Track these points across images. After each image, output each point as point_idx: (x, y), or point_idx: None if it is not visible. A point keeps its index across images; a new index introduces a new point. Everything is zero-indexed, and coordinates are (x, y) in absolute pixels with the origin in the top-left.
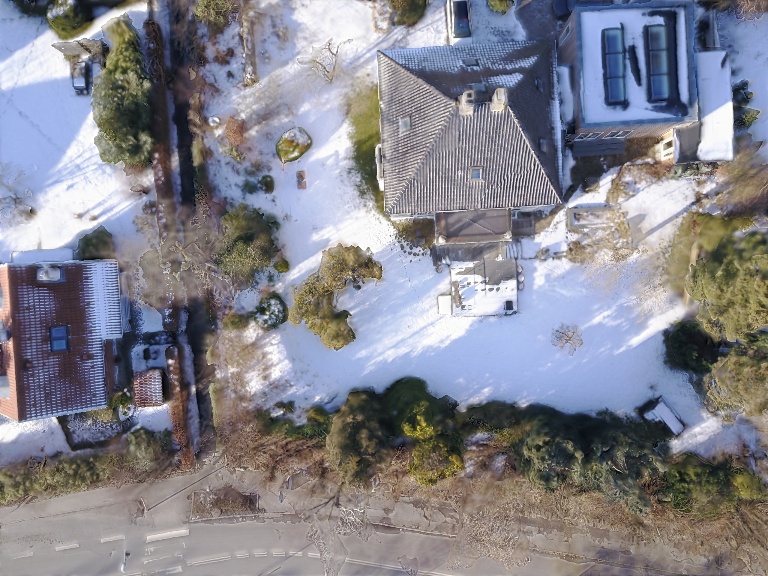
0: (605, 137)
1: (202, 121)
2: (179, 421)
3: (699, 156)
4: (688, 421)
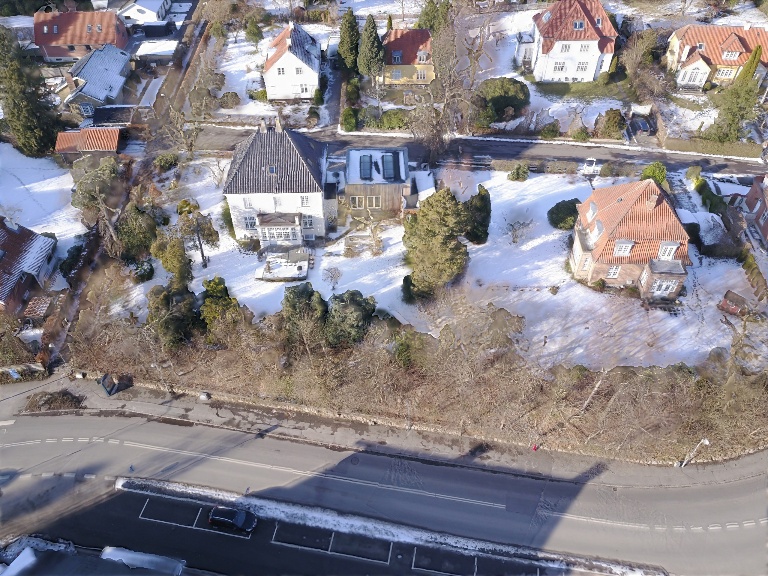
0: (369, 207)
1: (138, 197)
2: (49, 328)
3: (417, 206)
4: (418, 329)
